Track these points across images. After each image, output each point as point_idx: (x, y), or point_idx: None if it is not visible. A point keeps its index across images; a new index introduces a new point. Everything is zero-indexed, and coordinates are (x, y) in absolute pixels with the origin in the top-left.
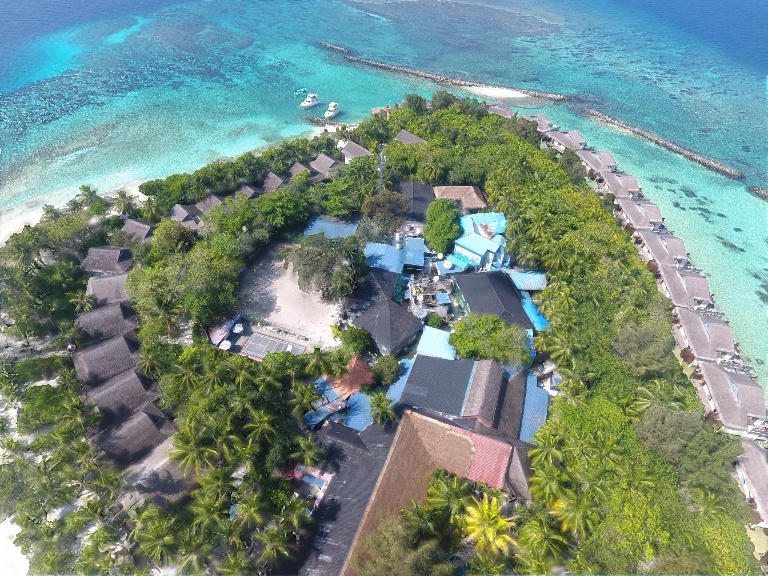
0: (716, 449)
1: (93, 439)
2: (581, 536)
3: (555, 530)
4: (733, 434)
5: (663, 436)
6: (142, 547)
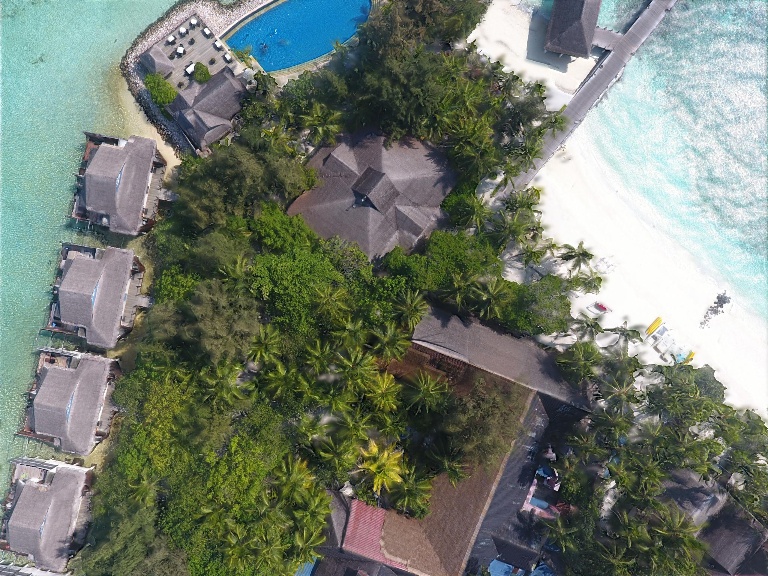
0: (119, 553)
1: (765, 540)
2: (292, 456)
3: (316, 461)
4: (49, 572)
5: (163, 567)
6: (695, 441)
